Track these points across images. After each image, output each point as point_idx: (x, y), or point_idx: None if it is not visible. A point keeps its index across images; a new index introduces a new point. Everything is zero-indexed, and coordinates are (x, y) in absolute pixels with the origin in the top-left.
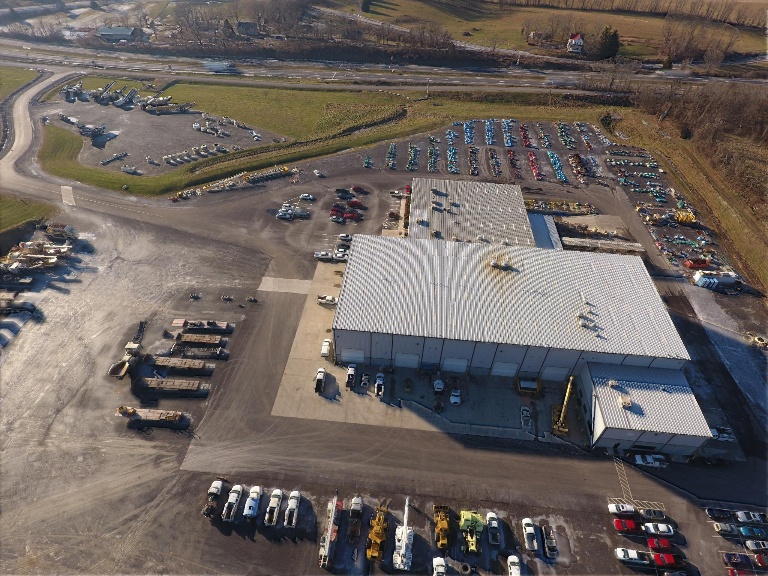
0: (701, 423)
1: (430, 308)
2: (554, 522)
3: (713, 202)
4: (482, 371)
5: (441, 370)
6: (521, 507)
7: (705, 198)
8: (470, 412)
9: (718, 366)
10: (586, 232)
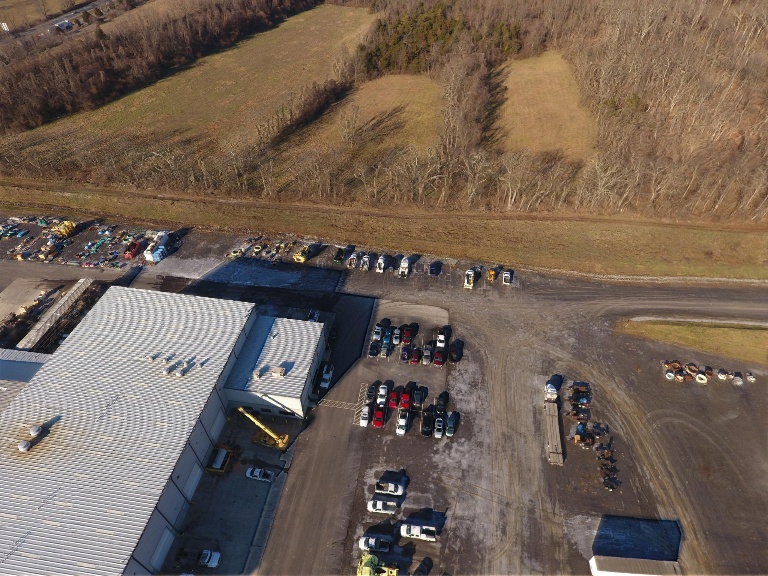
0: (311, 325)
1: (60, 571)
2: (371, 479)
3: (58, 201)
4: (183, 512)
5: (160, 573)
6: (355, 508)
7: (47, 203)
8: (235, 542)
9: (250, 290)
10: (19, 319)
